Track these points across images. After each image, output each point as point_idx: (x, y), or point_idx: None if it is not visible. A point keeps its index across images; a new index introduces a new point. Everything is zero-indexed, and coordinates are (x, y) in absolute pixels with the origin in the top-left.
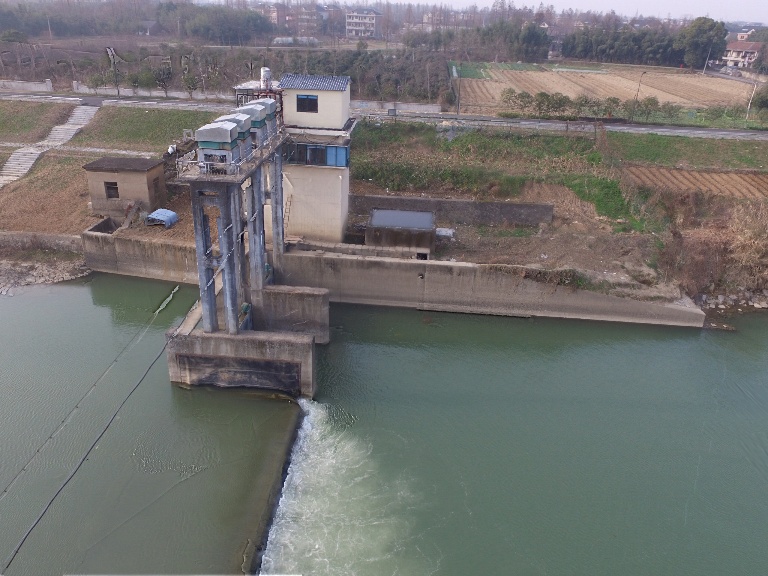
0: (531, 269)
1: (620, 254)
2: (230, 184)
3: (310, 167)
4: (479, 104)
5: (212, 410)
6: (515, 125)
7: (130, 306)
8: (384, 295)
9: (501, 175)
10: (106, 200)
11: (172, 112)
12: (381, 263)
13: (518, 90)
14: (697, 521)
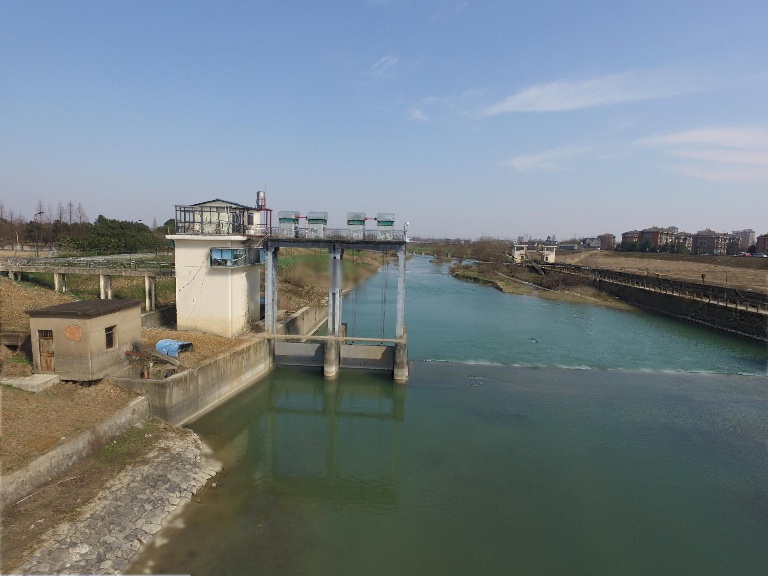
0: None
1: (287, 298)
2: None
3: None
4: None
5: None
6: (119, 257)
7: None
8: (297, 340)
9: None
10: (105, 354)
11: None
12: None
13: None
14: (455, 328)
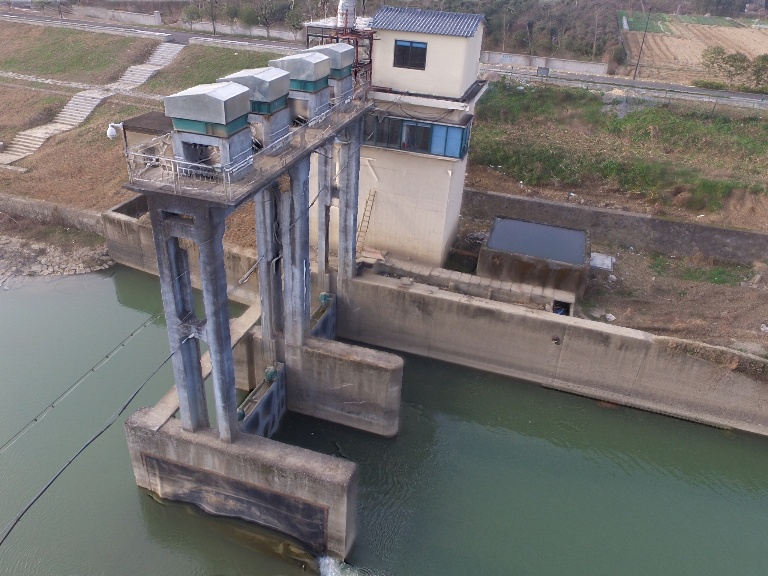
0: (748, 358)
1: None
2: (214, 205)
3: (405, 154)
4: (656, 65)
5: (194, 537)
6: (721, 101)
7: (158, 313)
8: (494, 358)
9: (695, 176)
10: None
11: (265, 56)
12: (495, 312)
13: (729, 50)
14: None
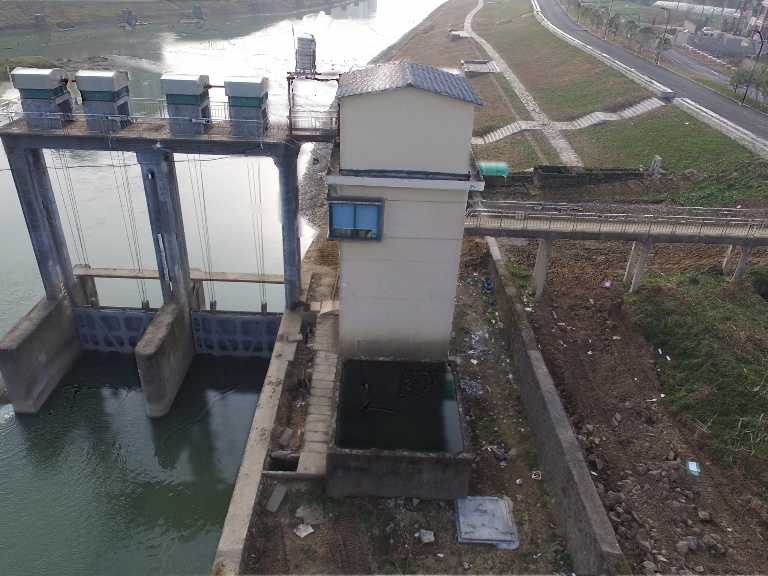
0: None
1: None
2: None
3: None
4: None
5: None
6: None
7: None
8: None
9: None
10: None
11: (707, 132)
12: None
13: None
14: None
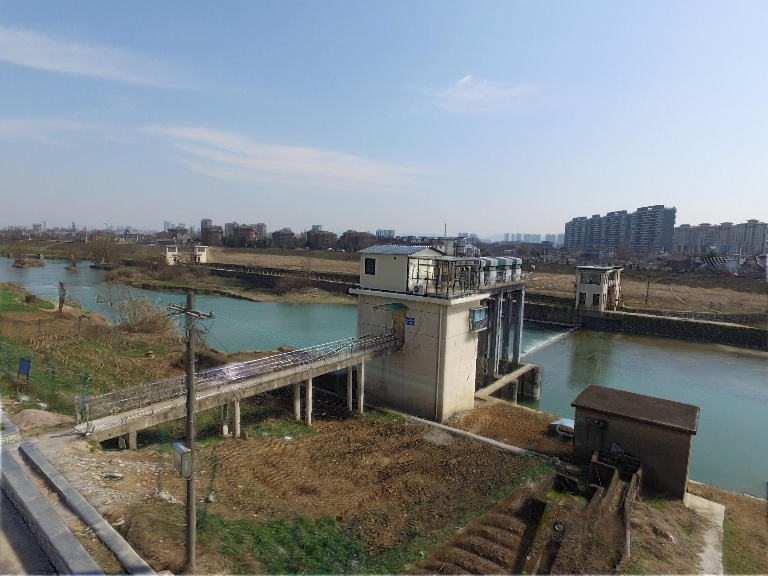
0: None
1: None
2: None
3: None
4: None
5: None
6: None
7: None
8: None
9: (131, 365)
10: None
11: None
12: None
13: None
14: None
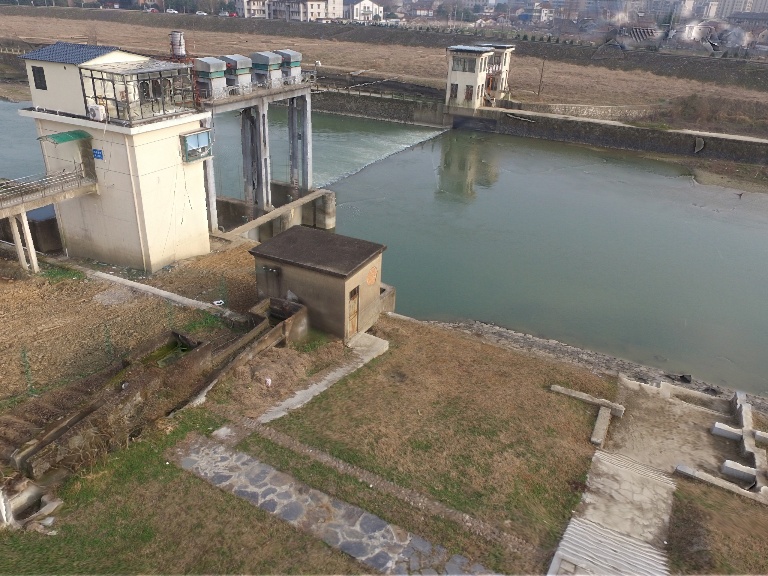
0: None
1: None
2: None
3: None
4: None
5: None
6: None
7: None
8: None
9: None
10: None
11: None
12: None
13: None
14: None
